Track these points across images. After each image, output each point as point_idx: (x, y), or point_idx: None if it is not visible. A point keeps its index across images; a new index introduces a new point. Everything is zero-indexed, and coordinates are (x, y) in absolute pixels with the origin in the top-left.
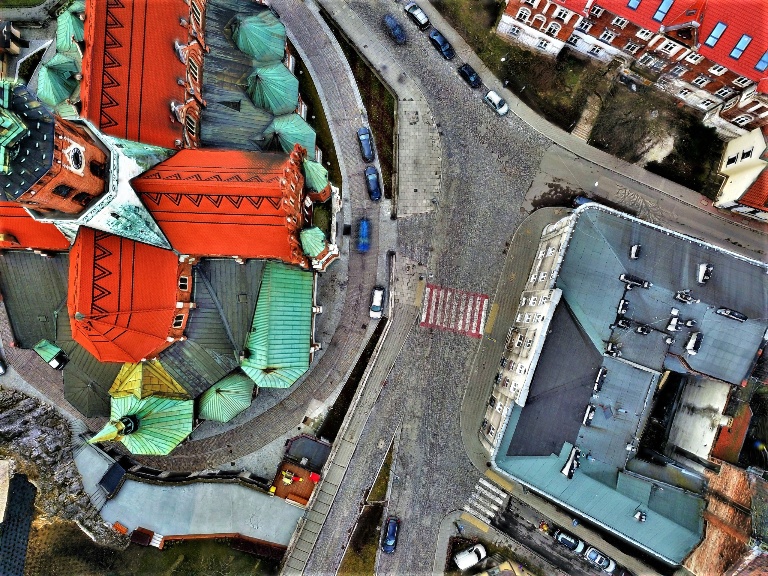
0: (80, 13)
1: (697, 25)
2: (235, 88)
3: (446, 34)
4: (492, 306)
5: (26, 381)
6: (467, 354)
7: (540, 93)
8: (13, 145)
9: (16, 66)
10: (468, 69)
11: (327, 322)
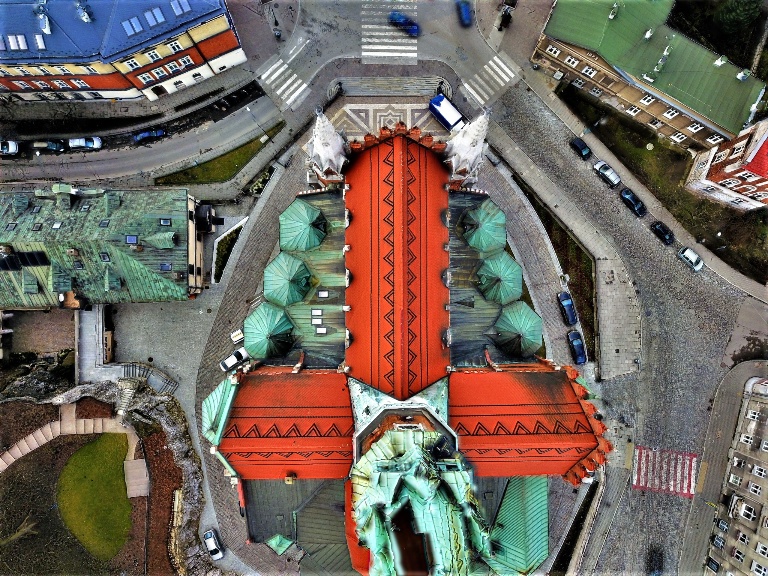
0: (316, 221)
1: None
2: (468, 284)
3: (636, 191)
4: (701, 465)
5: (244, 563)
6: (680, 515)
7: (733, 246)
8: None
9: (213, 245)
10: (663, 227)
11: None
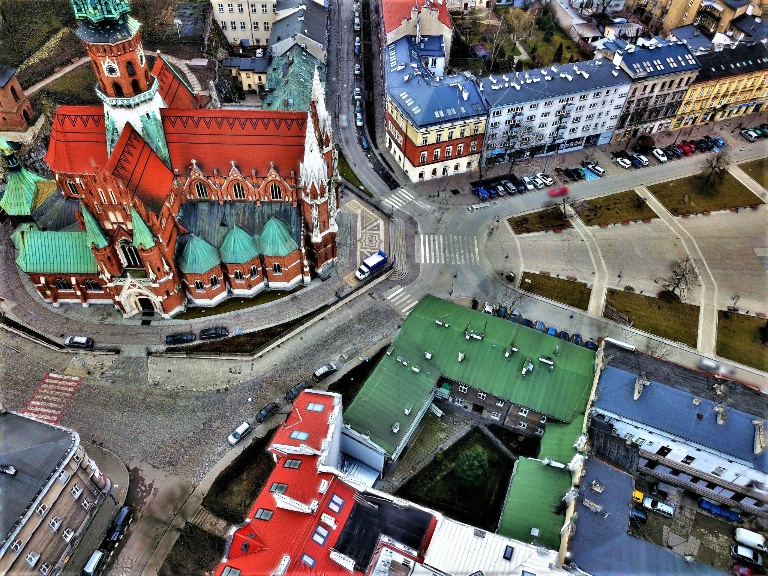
0: None
1: (231, 532)
2: (236, 223)
3: None
4: None
5: None
6: (6, 408)
7: (246, 474)
8: (89, 20)
9: None
10: (272, 408)
11: (75, 312)
